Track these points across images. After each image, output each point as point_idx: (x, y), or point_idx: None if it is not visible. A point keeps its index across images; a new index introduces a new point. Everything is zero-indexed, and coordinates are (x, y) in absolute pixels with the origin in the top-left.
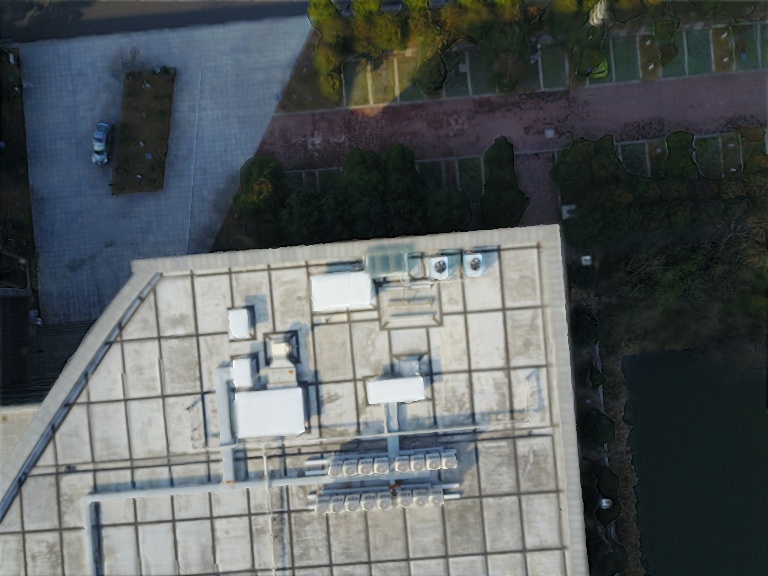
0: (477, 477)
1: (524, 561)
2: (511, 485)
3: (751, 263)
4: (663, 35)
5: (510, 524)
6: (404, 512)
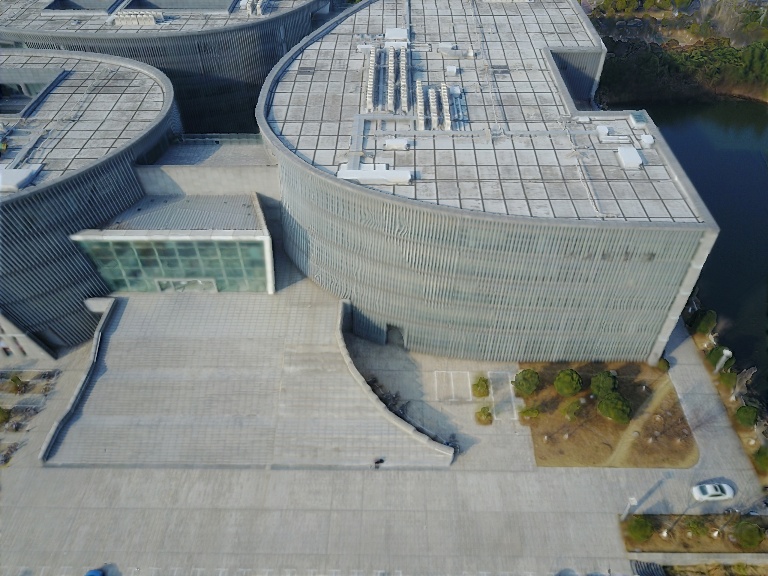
0: (540, 0)
1: (559, 9)
2: (551, 1)
3: (641, 47)
4: (595, 24)
5: (552, 5)
6: (515, 3)
